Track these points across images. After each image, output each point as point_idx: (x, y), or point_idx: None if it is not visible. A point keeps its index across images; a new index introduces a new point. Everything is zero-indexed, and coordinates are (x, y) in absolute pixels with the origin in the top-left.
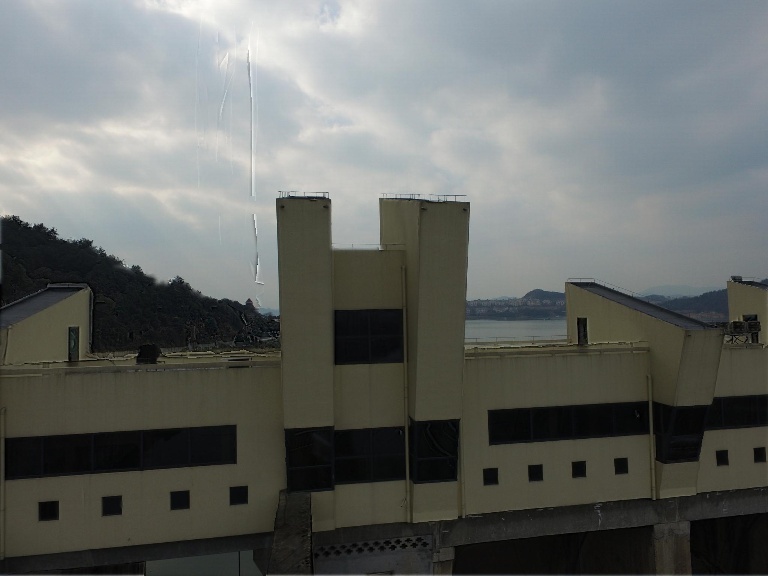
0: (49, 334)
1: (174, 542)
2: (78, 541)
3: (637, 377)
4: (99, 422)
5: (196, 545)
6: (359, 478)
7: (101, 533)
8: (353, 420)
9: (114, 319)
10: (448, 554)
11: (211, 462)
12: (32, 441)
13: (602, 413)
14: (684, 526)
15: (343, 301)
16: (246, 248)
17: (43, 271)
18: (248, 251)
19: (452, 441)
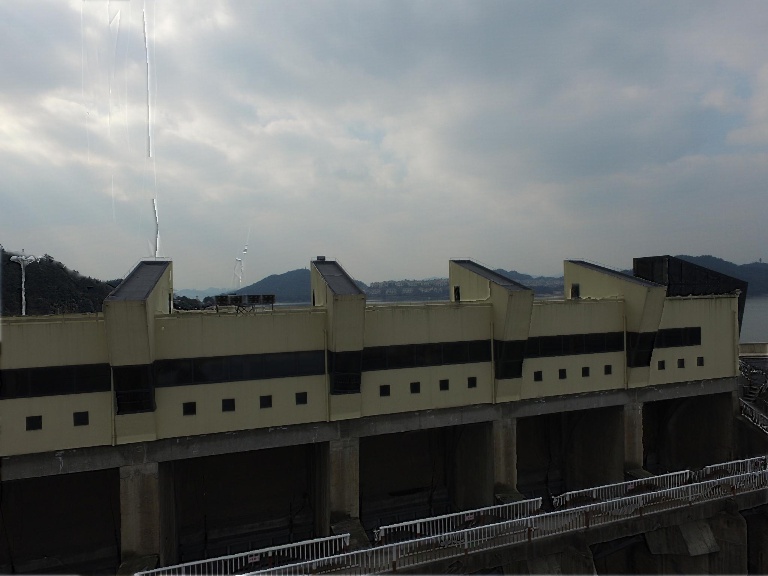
0: None
1: None
2: None
3: (101, 342)
4: None
5: None
6: None
7: None
8: None
9: None
10: None
11: None
12: None
13: (63, 374)
14: (151, 467)
15: None
16: (144, 225)
17: None
18: (146, 228)
19: None
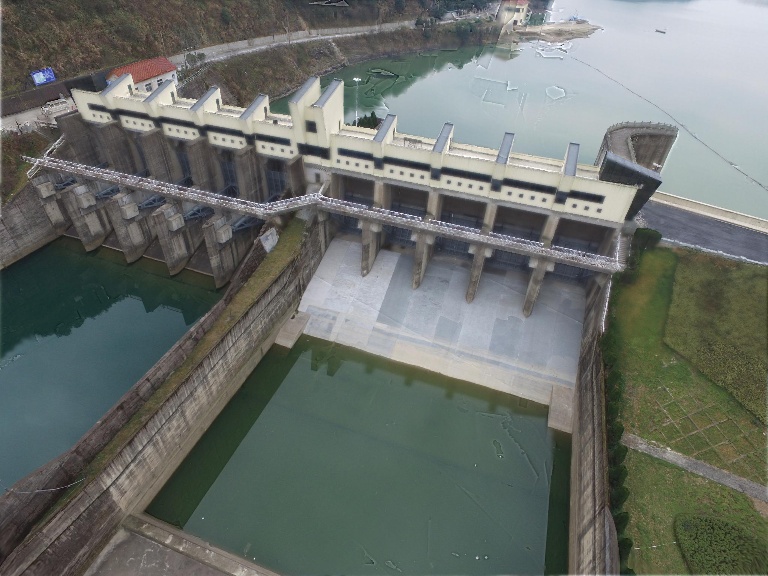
0: (260, 111)
1: (282, 157)
2: (268, 153)
3: None
4: (268, 133)
5: (286, 159)
6: (313, 155)
7: (271, 153)
8: (311, 143)
9: None
10: (330, 174)
11: (287, 145)
12: (259, 134)
13: (363, 154)
14: (382, 183)
15: (308, 118)
16: None
17: None
18: None
19: (327, 152)
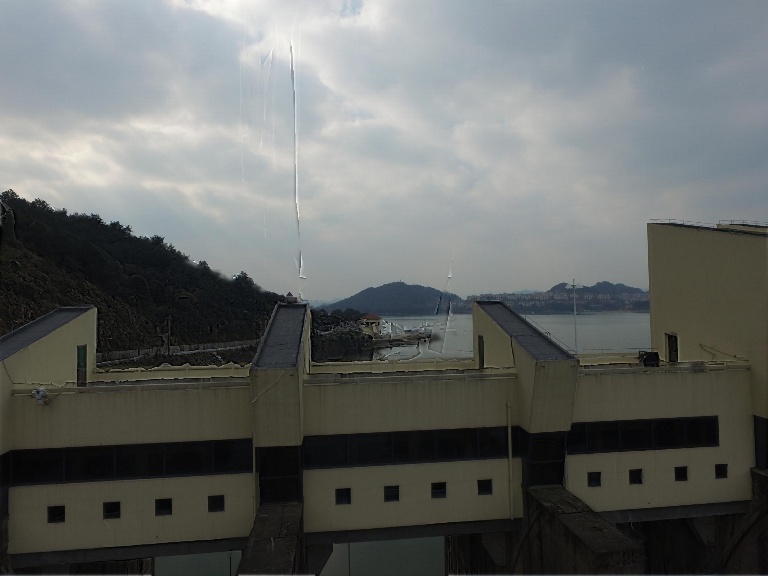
0: None
1: (677, 506)
2: (614, 503)
3: None
4: (624, 412)
5: (690, 509)
6: None
7: (629, 497)
8: None
9: (196, 313)
10: None
11: (700, 445)
12: (578, 426)
13: None
14: None
15: None
16: (290, 243)
17: (130, 267)
18: (292, 246)
19: None
